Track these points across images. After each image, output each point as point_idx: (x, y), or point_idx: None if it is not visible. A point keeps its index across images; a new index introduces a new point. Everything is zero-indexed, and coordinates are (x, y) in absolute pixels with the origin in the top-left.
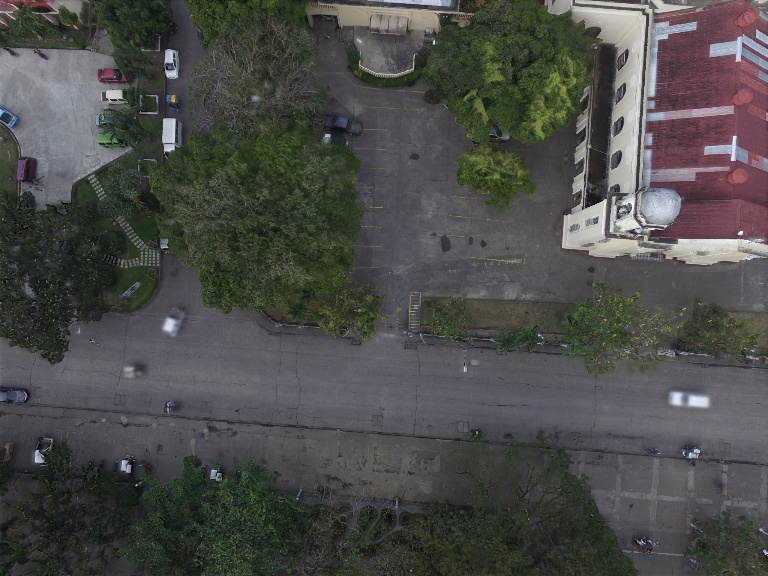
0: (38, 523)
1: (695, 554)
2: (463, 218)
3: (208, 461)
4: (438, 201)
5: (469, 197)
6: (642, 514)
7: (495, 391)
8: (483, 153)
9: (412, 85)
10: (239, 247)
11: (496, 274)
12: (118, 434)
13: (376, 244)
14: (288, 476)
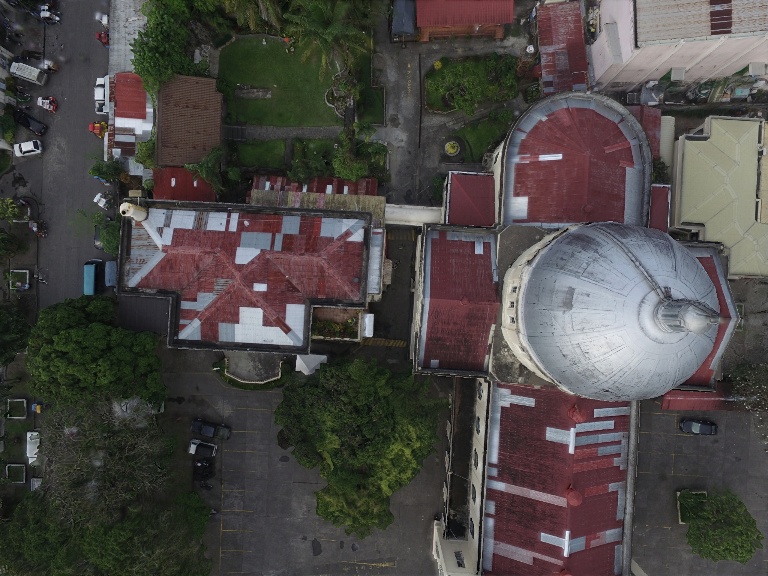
0: None
1: None
2: None
3: None
4: (308, 504)
5: None
6: None
7: None
8: (337, 492)
9: (281, 386)
10: None
11: None
12: None
13: (246, 549)
14: None
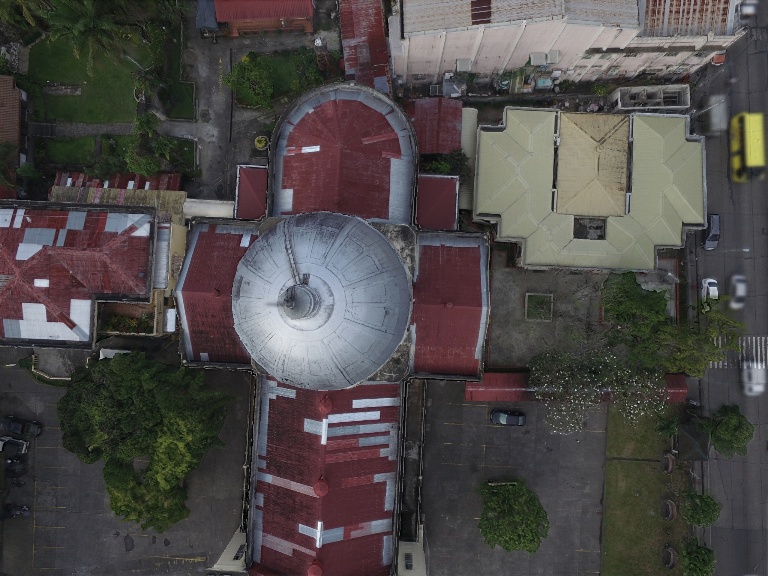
0: None
1: None
2: None
3: None
4: None
5: None
6: None
7: None
8: None
9: None
10: None
11: (180, 573)
12: None
13: (59, 545)
14: None
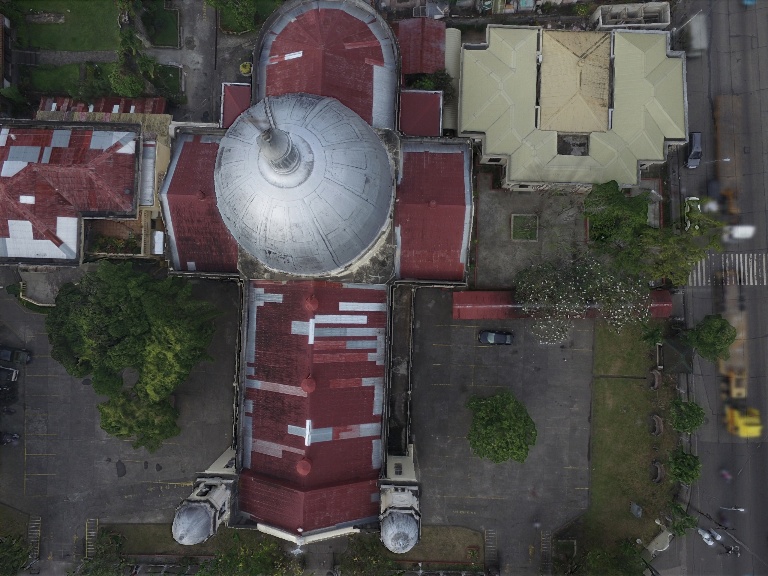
0: None
1: None
2: None
3: None
4: None
5: None
6: None
7: None
8: (116, 404)
9: None
10: None
11: (172, 497)
12: None
13: (51, 472)
14: None
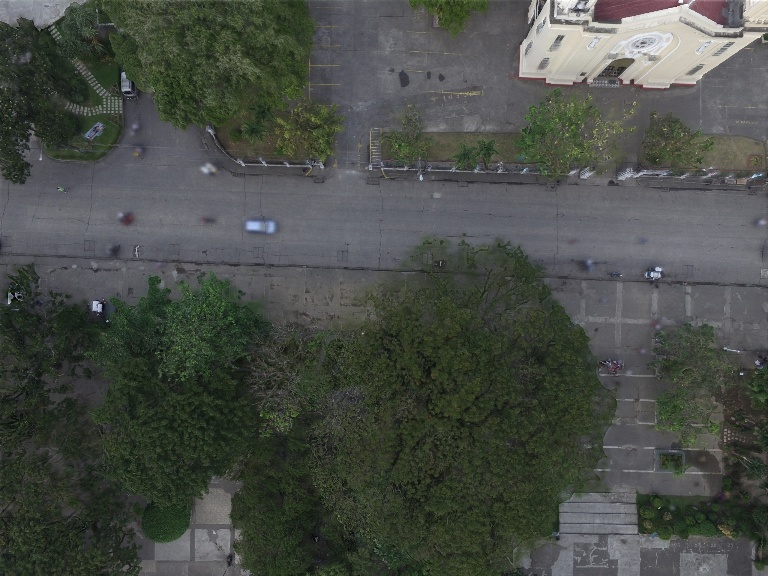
0: (5, 329)
1: (657, 362)
2: (420, 53)
3: (178, 302)
4: (395, 37)
5: (425, 31)
6: (607, 337)
7: (458, 222)
8: None
9: None
10: (187, 42)
11: (455, 107)
12: (89, 279)
13: (335, 82)
14: (257, 313)
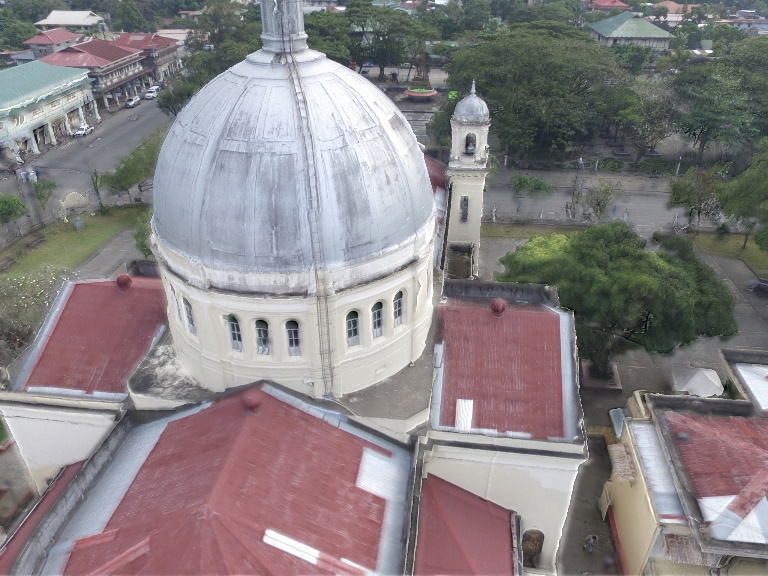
0: None
1: None
2: None
3: None
4: None
5: None
6: None
7: (529, 202)
8: None
9: None
10: None
11: None
12: None
13: None
14: None
